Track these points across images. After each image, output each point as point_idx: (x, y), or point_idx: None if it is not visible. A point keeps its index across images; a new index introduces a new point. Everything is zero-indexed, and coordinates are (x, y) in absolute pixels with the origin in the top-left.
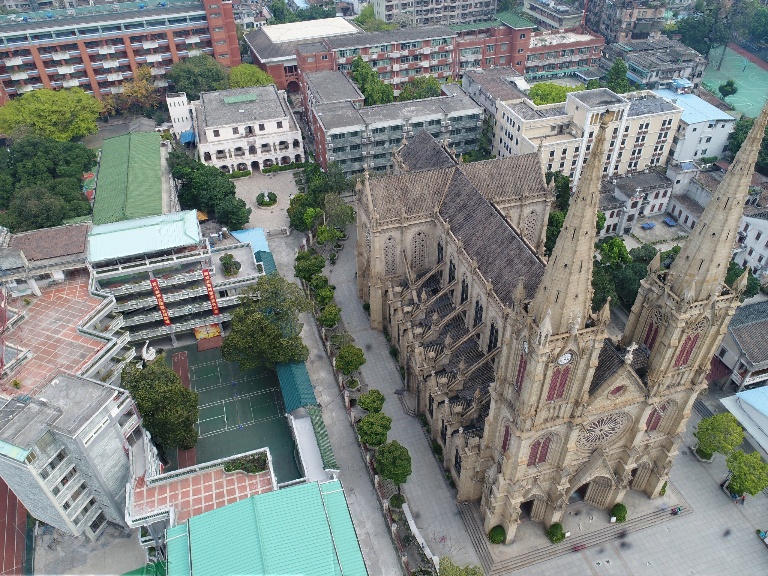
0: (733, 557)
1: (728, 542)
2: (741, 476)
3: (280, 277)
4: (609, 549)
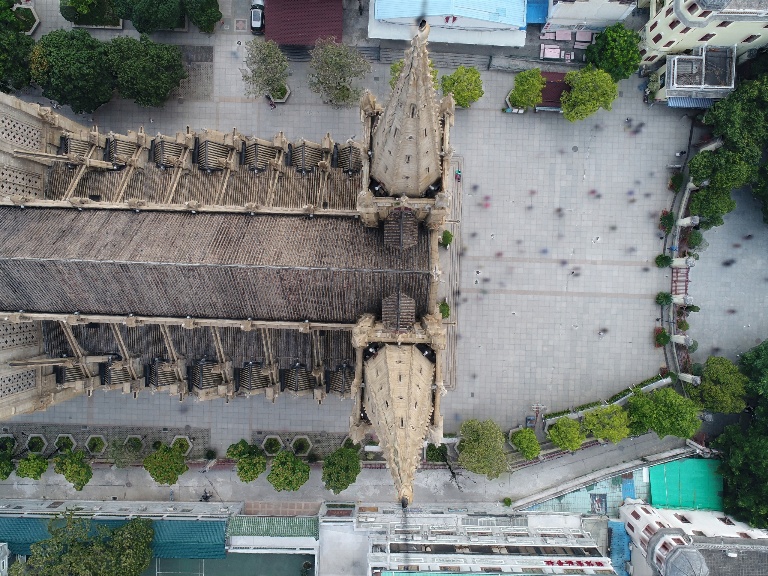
0: (515, 154)
1: (501, 147)
2: (467, 99)
3: (21, 575)
4: (468, 264)
